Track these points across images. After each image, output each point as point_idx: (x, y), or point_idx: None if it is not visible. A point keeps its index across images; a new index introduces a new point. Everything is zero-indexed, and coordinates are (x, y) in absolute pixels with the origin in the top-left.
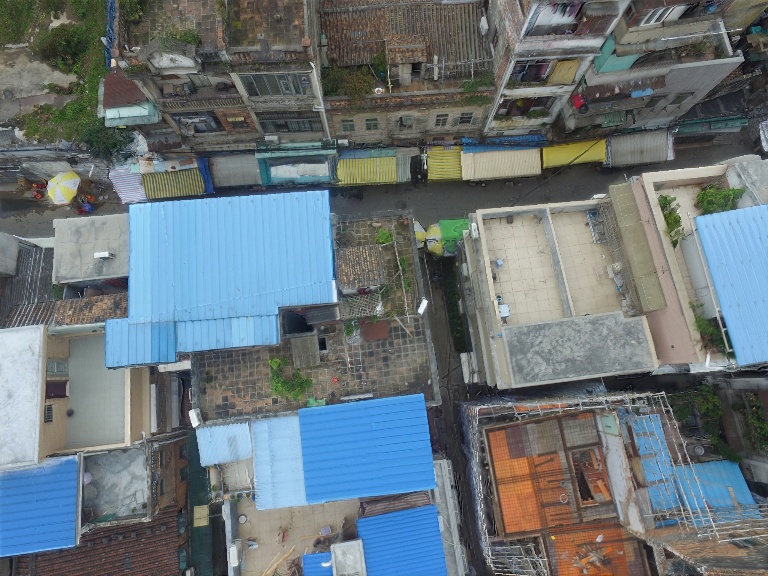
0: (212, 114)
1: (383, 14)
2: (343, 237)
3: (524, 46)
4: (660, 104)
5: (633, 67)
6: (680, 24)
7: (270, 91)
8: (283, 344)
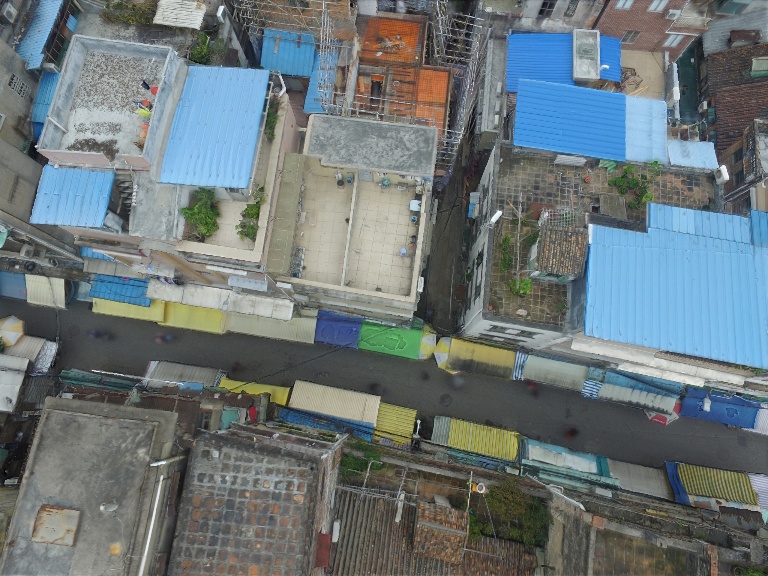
0: None
1: None
2: (560, 308)
3: None
4: None
5: None
6: None
7: None
8: None
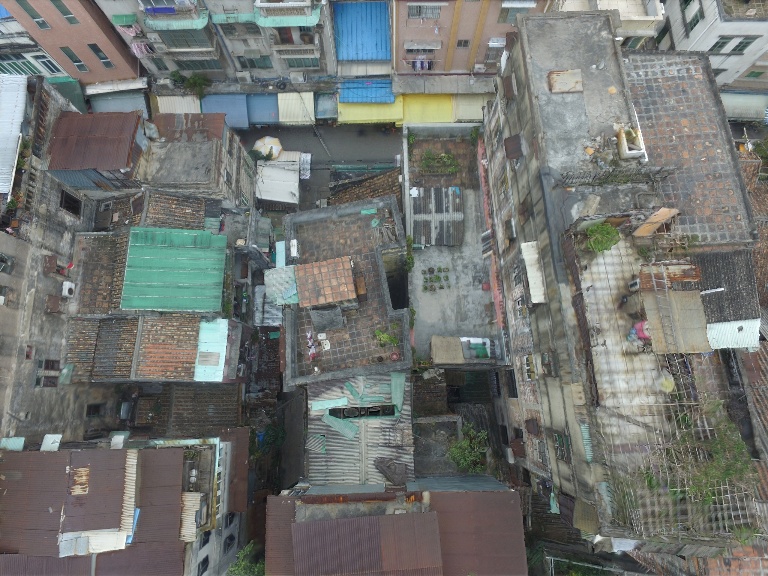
0: None
1: (759, 213)
2: None
3: None
4: None
5: None
6: None
7: None
8: None
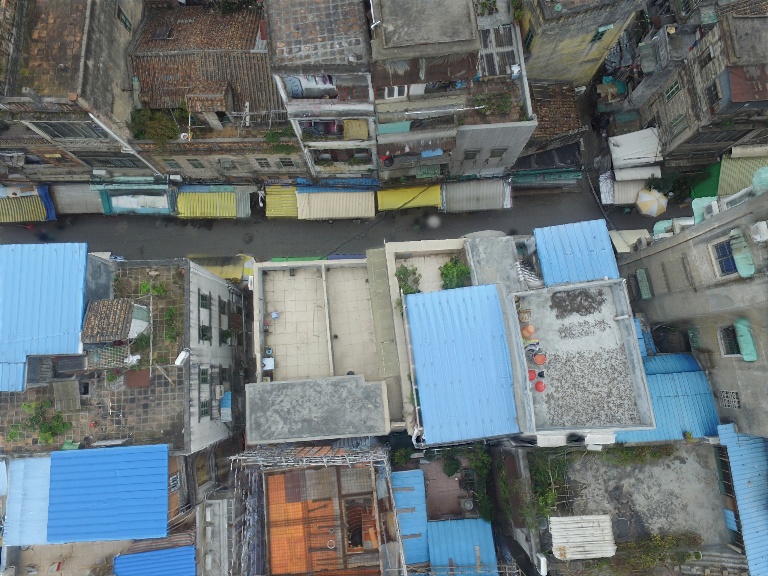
0: (27, 150)
1: (193, 60)
2: (120, 284)
3: (294, 107)
4: (480, 157)
5: (413, 129)
6: (426, 98)
7: (71, 133)
8: (50, 386)
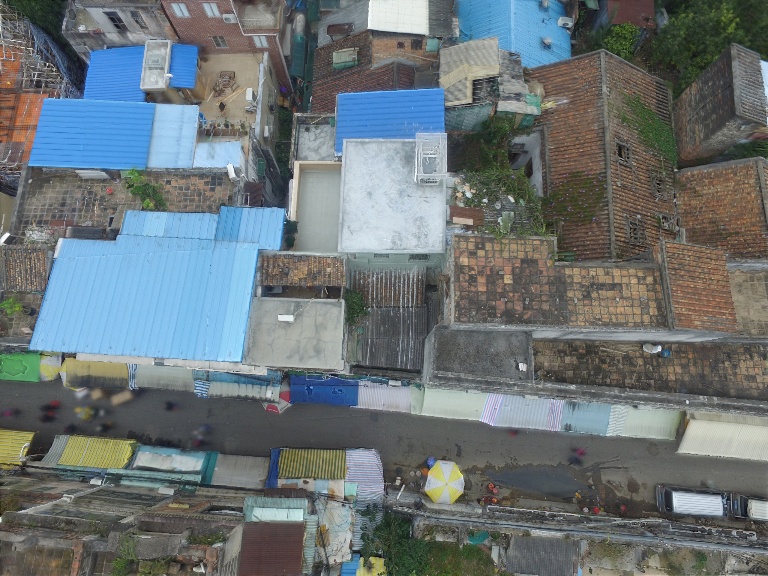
0: None
1: None
2: None
3: None
4: None
5: None
6: None
7: None
8: None
